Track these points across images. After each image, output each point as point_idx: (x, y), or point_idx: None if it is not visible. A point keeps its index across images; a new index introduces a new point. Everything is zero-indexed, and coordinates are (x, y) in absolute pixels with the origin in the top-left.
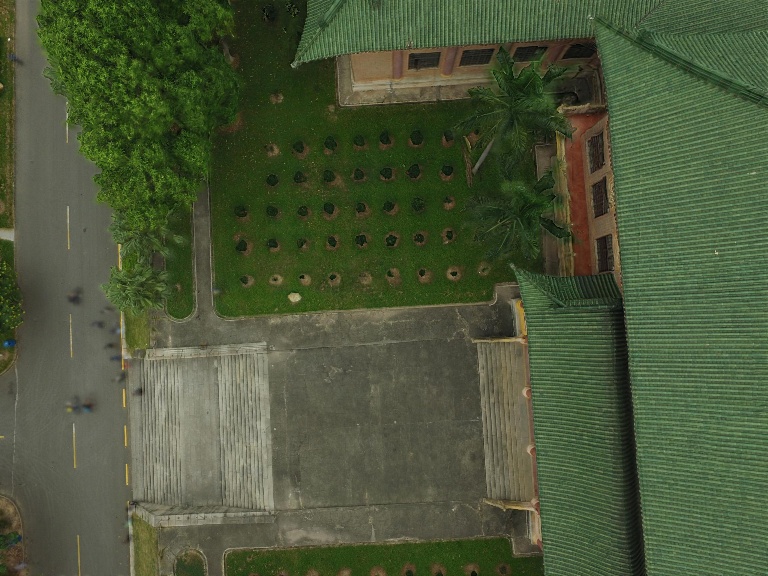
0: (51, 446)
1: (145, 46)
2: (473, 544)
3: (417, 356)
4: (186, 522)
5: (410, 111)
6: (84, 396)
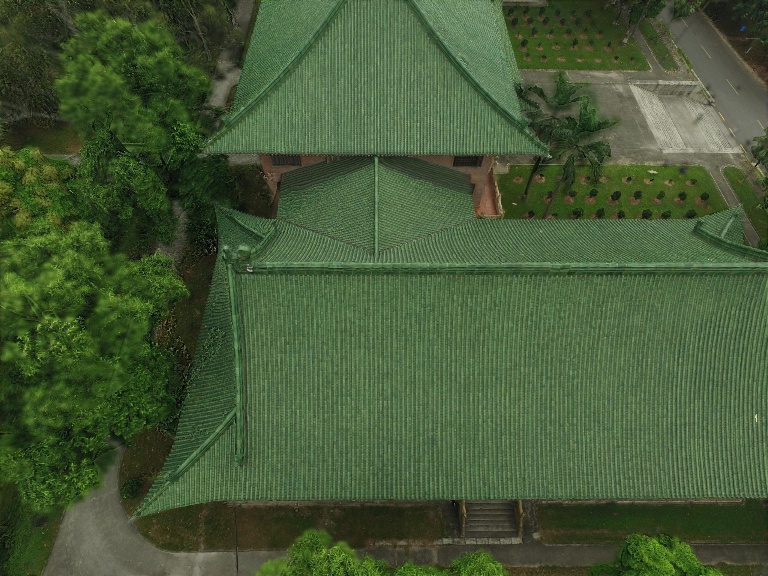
0: None
1: None
2: None
3: None
4: (680, 82)
5: None
6: None
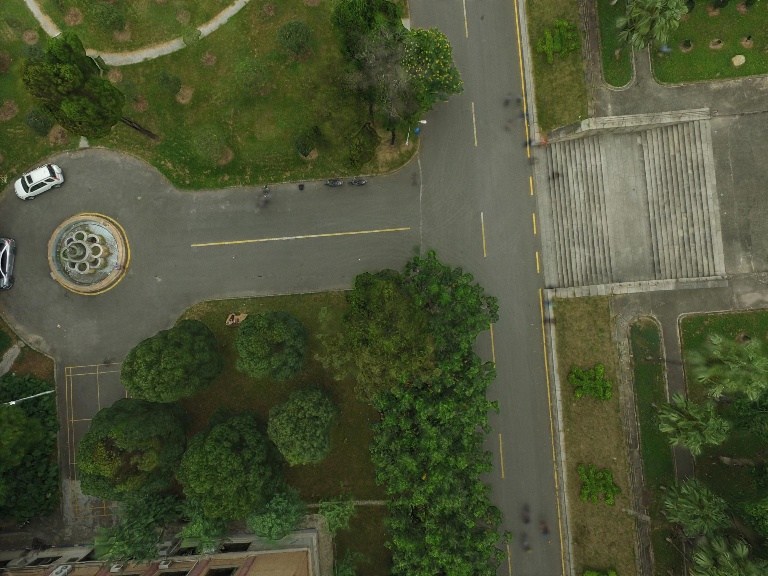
0: (459, 236)
1: None
2: None
3: None
4: (638, 289)
5: None
6: (491, 185)
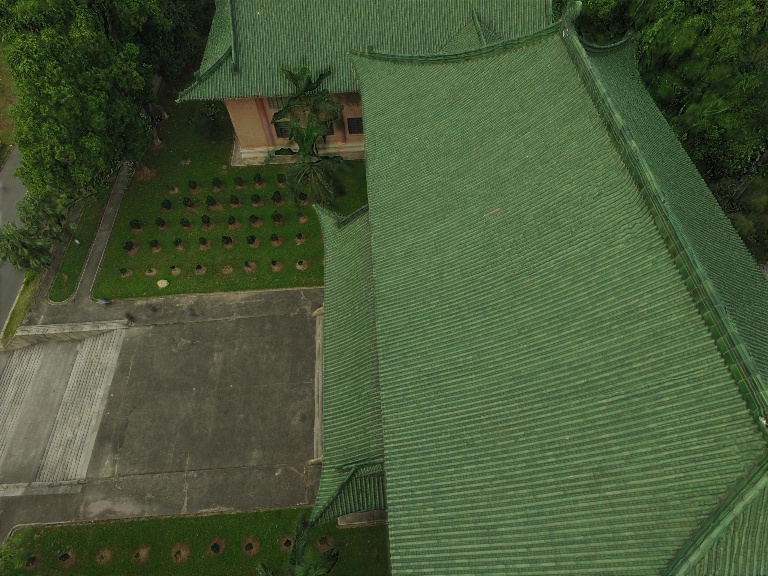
0: None
1: (71, 65)
2: (294, 513)
3: (262, 328)
4: None
5: (282, 168)
6: None
